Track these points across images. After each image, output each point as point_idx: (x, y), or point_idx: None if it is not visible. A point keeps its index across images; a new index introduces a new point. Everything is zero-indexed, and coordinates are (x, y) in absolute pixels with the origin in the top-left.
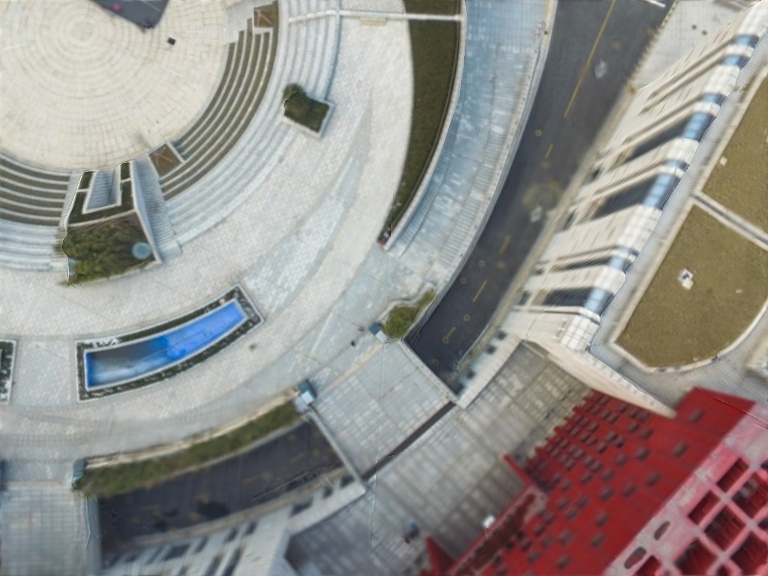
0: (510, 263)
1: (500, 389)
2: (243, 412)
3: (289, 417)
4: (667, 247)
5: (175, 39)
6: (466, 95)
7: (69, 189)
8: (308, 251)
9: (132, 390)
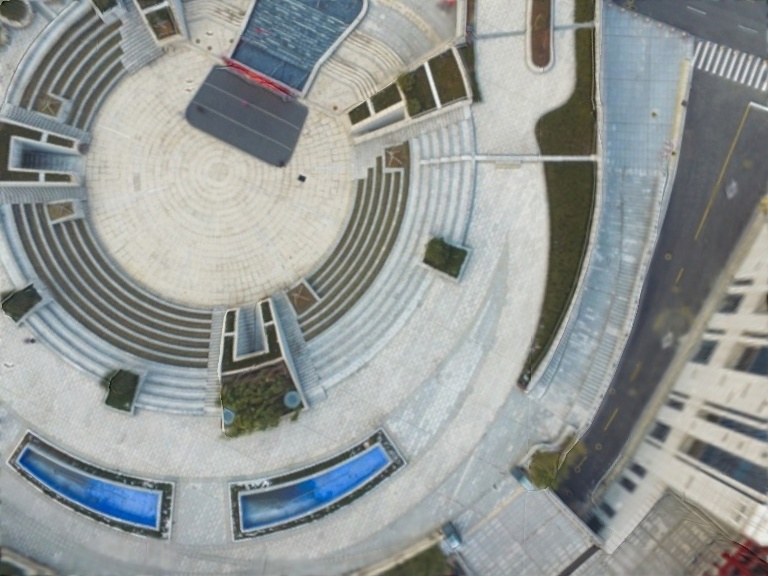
0: (642, 391)
1: (644, 532)
2: (389, 554)
3: (437, 563)
4: None
5: (305, 176)
6: None
7: (213, 328)
8: (448, 394)
9: (283, 531)
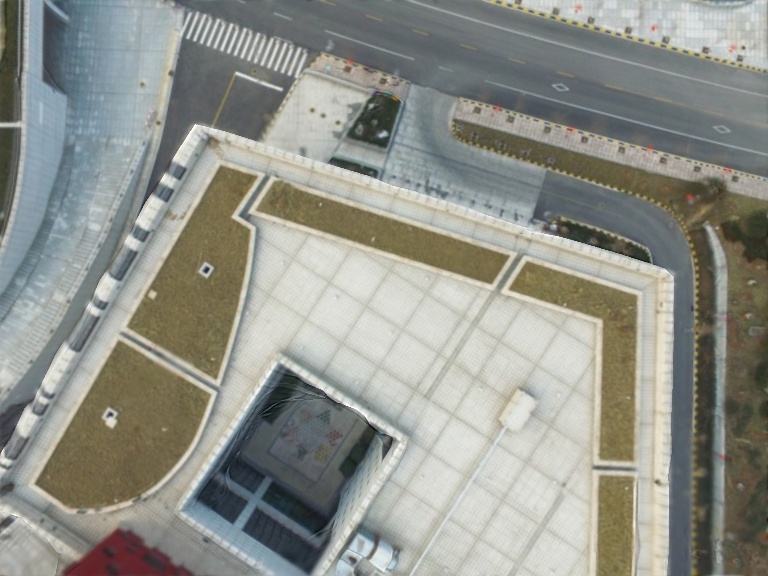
0: None
1: None
2: None
3: None
4: (88, 386)
5: None
6: (67, 192)
7: None
8: None
9: None
